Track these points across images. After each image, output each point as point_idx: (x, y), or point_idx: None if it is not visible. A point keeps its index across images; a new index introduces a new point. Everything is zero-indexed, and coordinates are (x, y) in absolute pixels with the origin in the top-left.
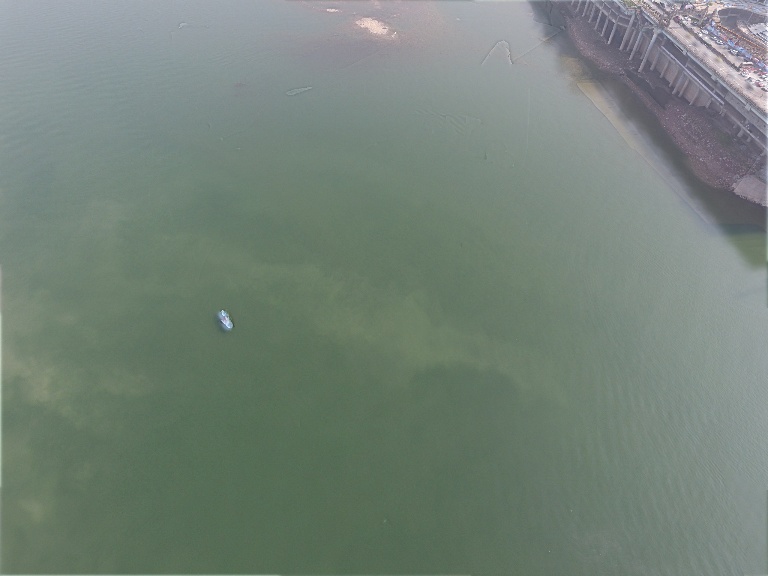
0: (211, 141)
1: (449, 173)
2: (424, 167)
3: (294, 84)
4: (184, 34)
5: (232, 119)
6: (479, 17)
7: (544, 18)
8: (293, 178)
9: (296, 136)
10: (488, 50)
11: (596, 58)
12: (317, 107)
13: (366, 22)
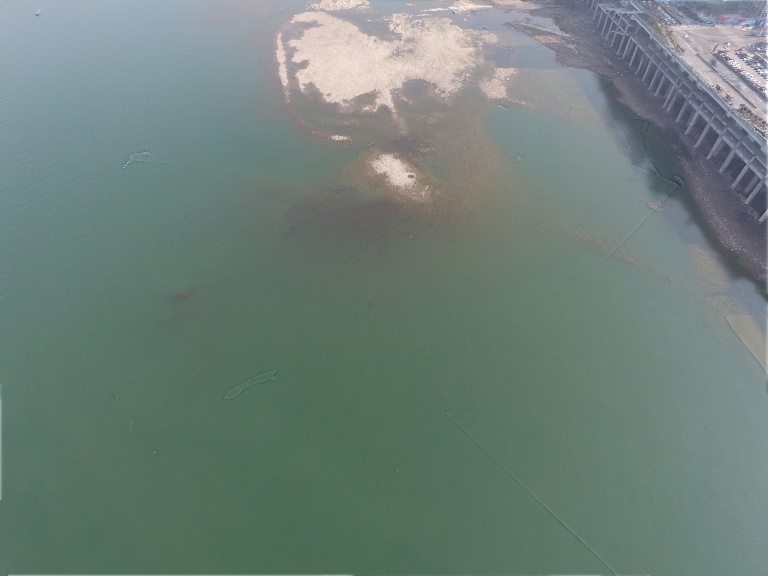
0: (112, 431)
1: (519, 569)
2: (471, 542)
3: (267, 289)
4: (126, 181)
5: (158, 371)
6: (549, 152)
7: (638, 142)
8: (226, 572)
9: (248, 442)
10: (569, 227)
11: (747, 254)
12: (298, 338)
13: (385, 163)
